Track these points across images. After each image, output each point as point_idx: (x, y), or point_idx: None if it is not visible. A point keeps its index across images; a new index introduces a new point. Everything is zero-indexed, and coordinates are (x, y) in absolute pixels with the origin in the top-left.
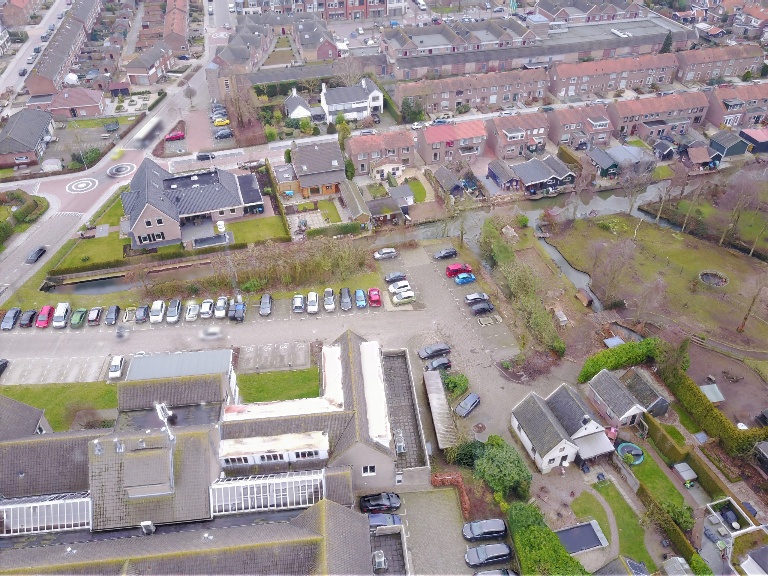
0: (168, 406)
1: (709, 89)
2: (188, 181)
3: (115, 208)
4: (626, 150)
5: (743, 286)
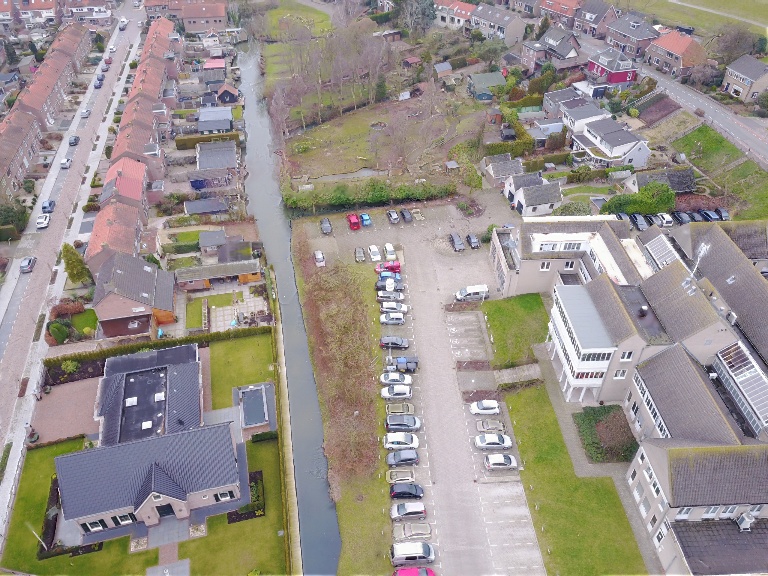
0: (633, 314)
1: (107, 66)
2: (136, 410)
3: (90, 572)
4: (210, 112)
5: (387, 119)
